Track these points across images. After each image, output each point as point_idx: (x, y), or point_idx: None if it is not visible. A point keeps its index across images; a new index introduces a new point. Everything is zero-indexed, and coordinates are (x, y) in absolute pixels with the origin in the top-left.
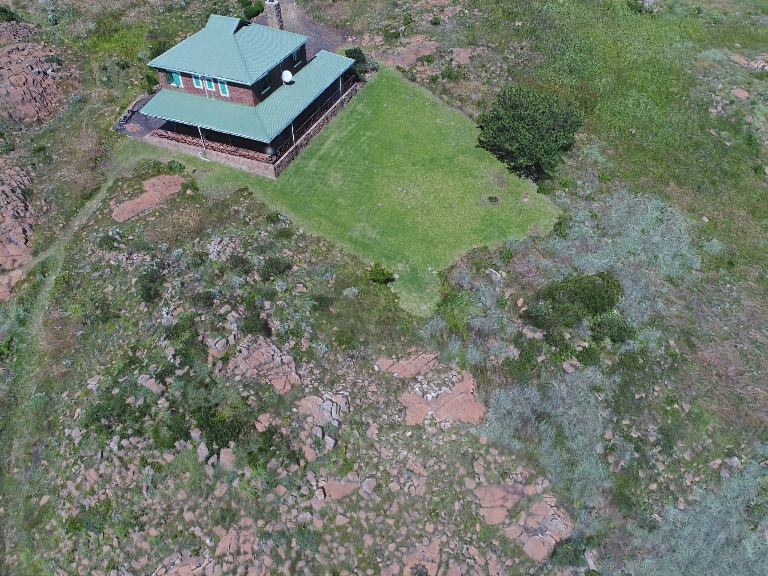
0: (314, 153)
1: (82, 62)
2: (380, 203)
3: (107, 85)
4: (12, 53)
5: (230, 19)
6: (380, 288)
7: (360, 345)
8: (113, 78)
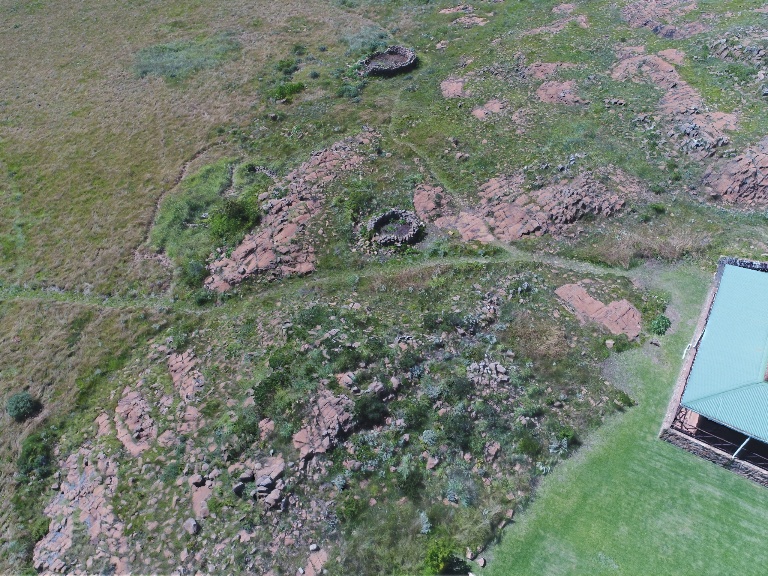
0: (741, 494)
1: None
2: None
3: None
4: None
5: None
6: None
7: (346, 529)
8: None
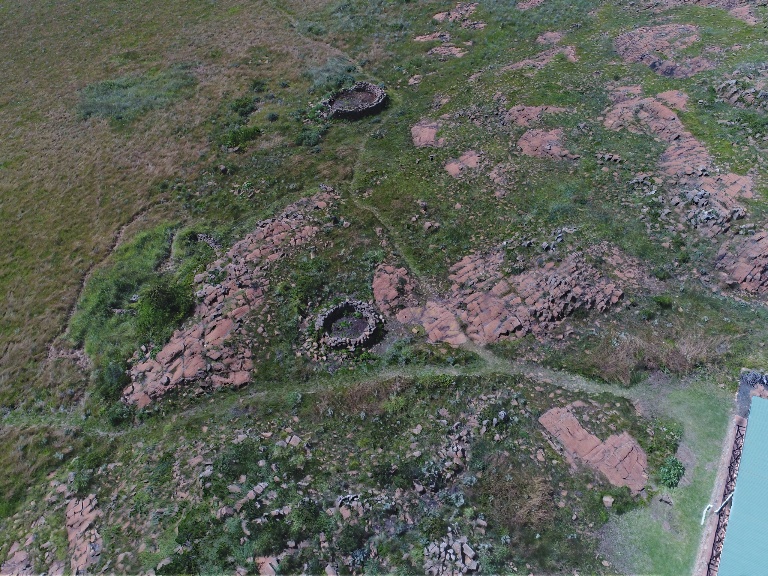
0: None
1: None
2: None
3: None
4: None
5: None
6: None
7: None
8: None
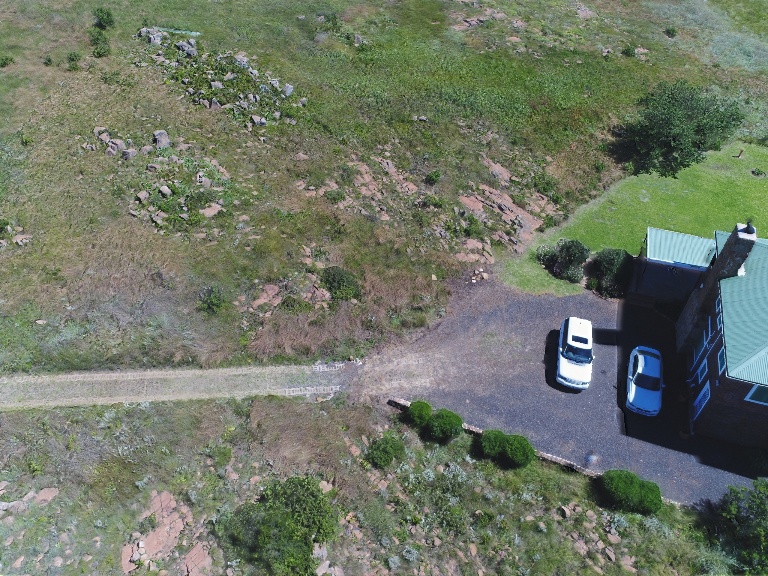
0: None
1: None
2: None
3: None
4: None
5: None
6: None
7: None
8: None
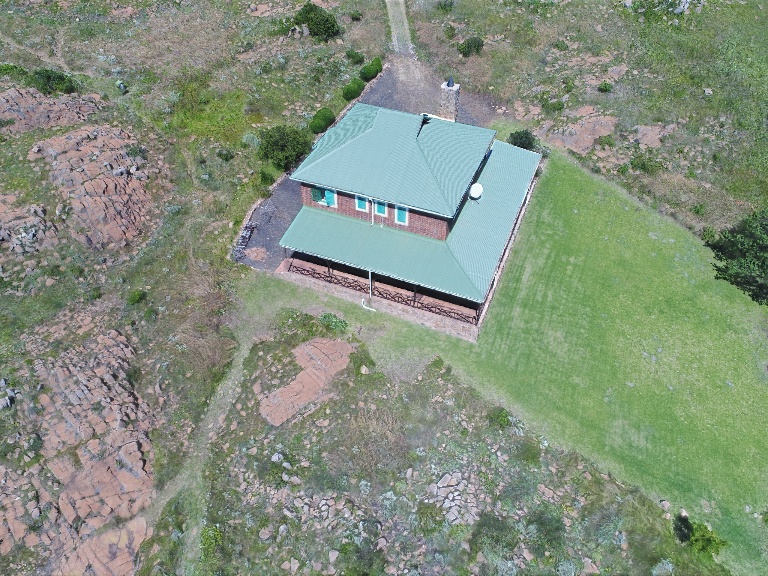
0: (513, 295)
1: (171, 151)
2: (630, 382)
3: (209, 185)
4: (82, 144)
5: (409, 117)
6: (698, 557)
7: None
8: (215, 174)
